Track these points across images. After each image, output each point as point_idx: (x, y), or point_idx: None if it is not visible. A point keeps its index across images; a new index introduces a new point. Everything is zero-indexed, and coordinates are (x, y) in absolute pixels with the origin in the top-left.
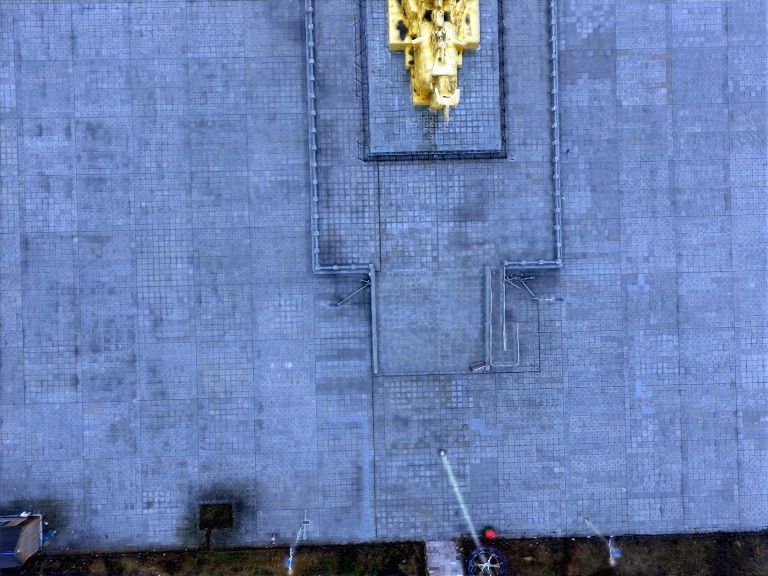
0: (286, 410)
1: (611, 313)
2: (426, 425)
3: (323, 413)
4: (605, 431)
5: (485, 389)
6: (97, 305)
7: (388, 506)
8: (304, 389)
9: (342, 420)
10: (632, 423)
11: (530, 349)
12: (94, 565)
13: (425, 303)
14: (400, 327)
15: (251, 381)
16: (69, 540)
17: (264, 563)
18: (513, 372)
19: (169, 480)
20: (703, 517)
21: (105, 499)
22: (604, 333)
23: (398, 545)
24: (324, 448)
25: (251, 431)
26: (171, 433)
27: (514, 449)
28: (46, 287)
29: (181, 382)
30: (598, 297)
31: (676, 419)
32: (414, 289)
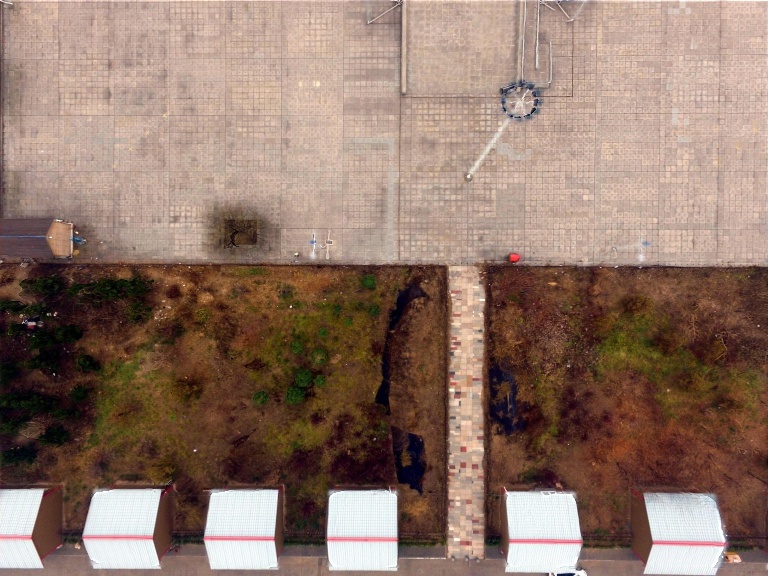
0: (313, 129)
1: (649, 37)
2: (453, 148)
3: (350, 133)
4: (638, 159)
5: (515, 113)
6: (130, 19)
7: (412, 229)
8: (331, 109)
9: (368, 141)
10: (667, 152)
11: (563, 73)
12: (122, 272)
13: (457, 19)
14: (430, 45)
15: (279, 99)
16: (98, 250)
17: (287, 278)
18: (544, 96)
19: (196, 195)
20: (738, 251)
21: (134, 211)
22: (641, 58)
23: (421, 266)
24: (349, 168)
25: (277, 149)
26: (199, 149)
27: (542, 175)
28: (82, 0)
29: (210, 98)
30: (636, 20)
31: (713, 149)
32: (446, 4)
